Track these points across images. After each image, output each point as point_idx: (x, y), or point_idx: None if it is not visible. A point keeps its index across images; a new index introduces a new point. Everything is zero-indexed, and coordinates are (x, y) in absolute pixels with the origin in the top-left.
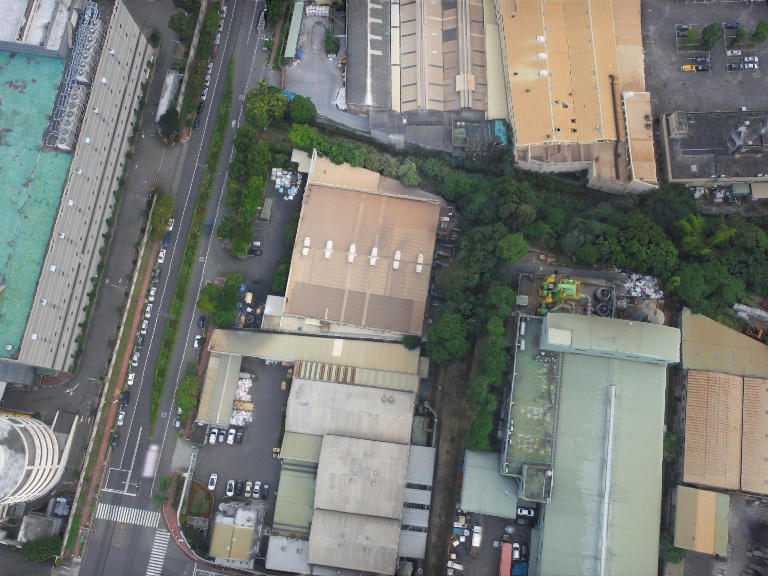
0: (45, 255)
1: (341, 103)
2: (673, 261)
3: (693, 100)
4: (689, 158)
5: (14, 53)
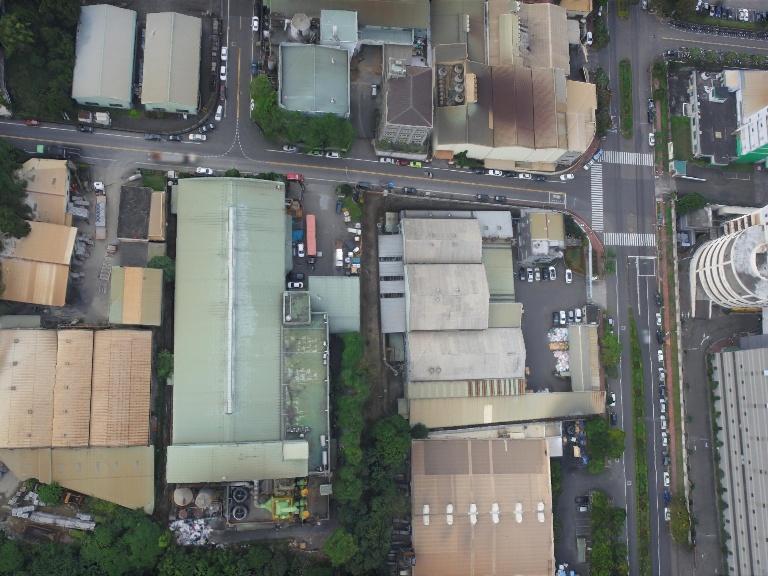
0: None
1: None
2: (166, 565)
3: None
4: None
5: None
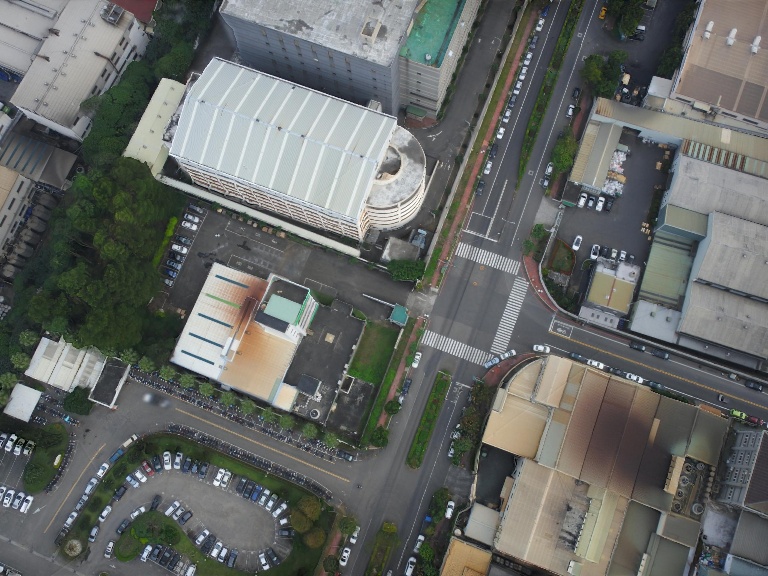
0: None
1: None
2: None
3: None
4: None
5: None
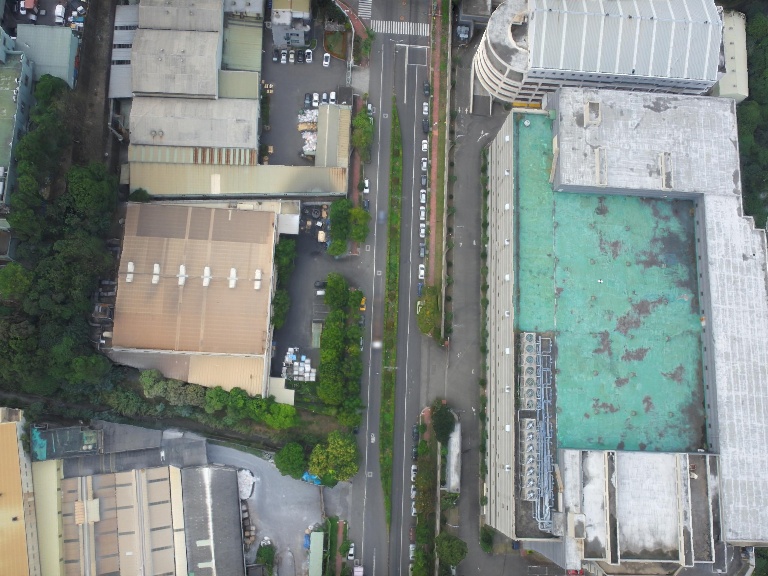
0: (518, 218)
1: (246, 477)
2: None
3: None
4: None
5: (620, 449)
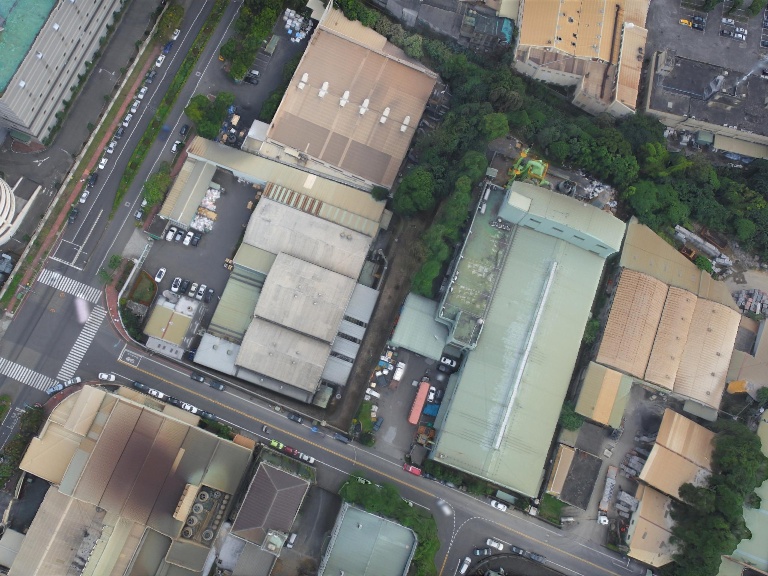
0: (51, 12)
1: None
2: (633, 173)
3: (683, 52)
4: (668, 95)
5: None
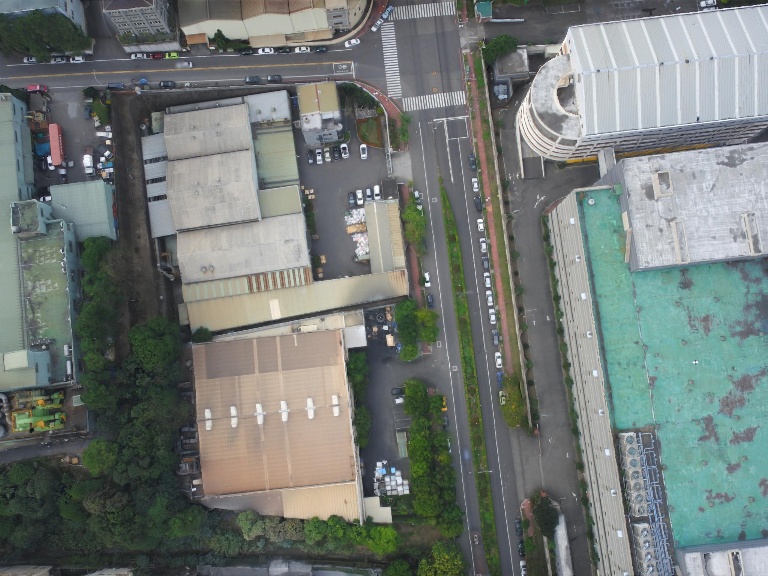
0: (597, 307)
1: None
2: None
3: None
4: None
5: (742, 540)
